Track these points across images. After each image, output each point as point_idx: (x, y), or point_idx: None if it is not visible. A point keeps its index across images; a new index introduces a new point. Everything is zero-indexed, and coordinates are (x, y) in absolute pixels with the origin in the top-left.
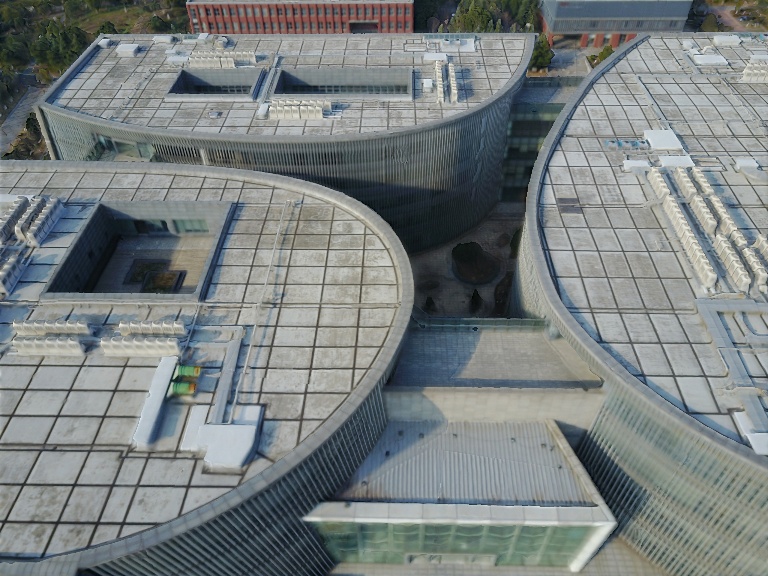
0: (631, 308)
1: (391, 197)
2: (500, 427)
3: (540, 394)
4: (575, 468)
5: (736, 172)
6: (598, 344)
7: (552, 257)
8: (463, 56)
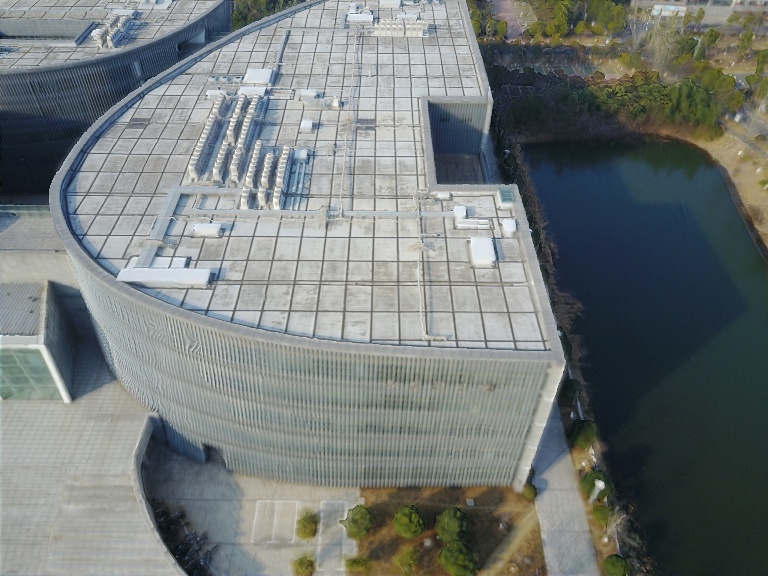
0: (120, 192)
1: (55, 129)
2: (4, 286)
3: (18, 254)
4: (40, 311)
5: (299, 100)
6: (62, 213)
7: (87, 158)
8: (153, 13)
